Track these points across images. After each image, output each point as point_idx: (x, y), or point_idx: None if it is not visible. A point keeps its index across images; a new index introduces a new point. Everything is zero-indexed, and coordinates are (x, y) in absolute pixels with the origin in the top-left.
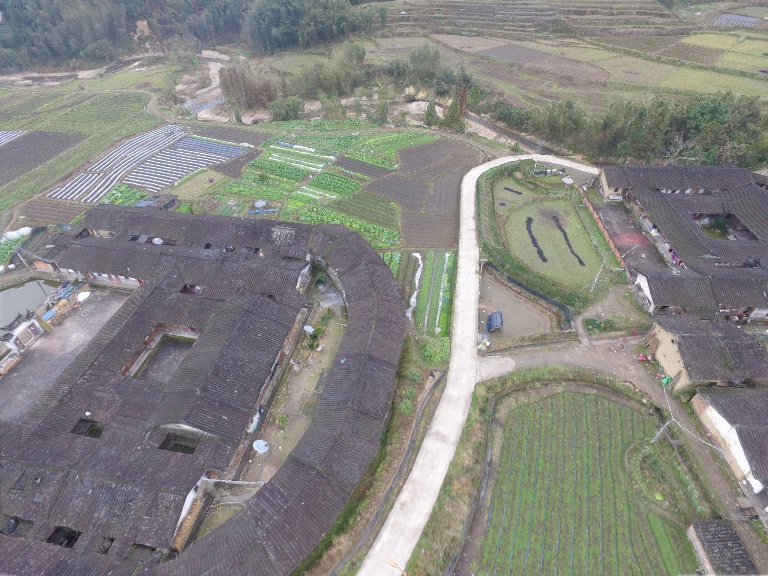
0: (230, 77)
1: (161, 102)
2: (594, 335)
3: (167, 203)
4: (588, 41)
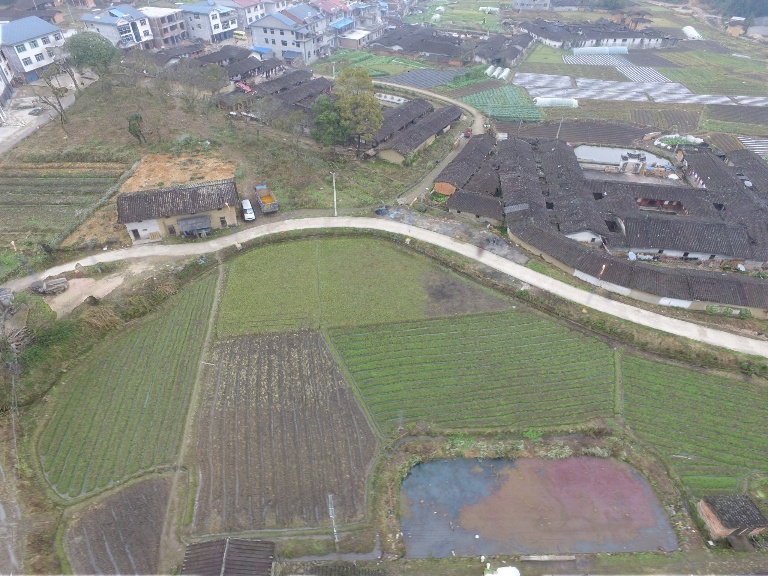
0: None
1: None
2: None
3: None
4: None
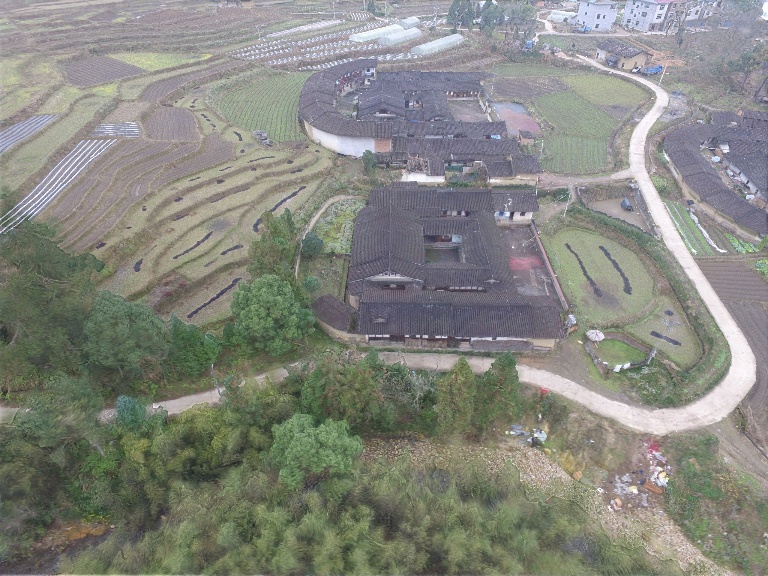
0: None
1: None
2: None
3: None
4: None
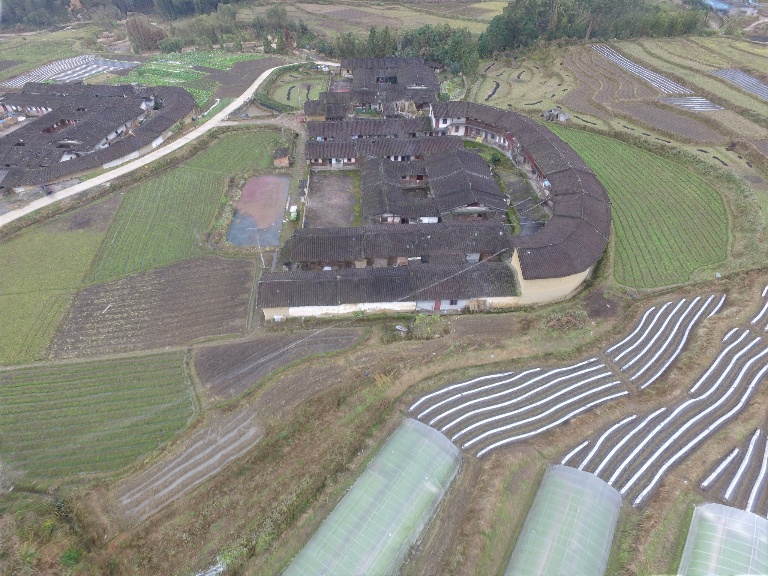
0: (132, 26)
1: (83, 45)
2: (285, 115)
3: (75, 83)
4: (406, 6)
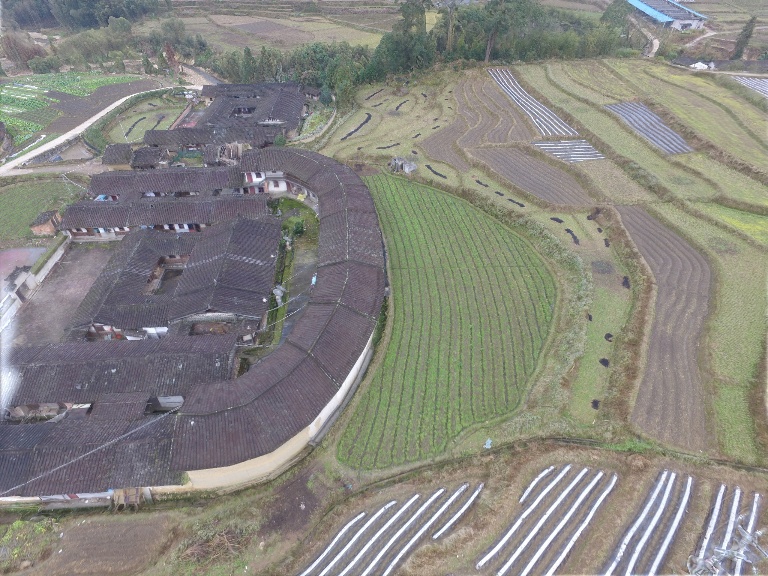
0: (5, 43)
1: None
2: None
3: None
4: (327, 18)
